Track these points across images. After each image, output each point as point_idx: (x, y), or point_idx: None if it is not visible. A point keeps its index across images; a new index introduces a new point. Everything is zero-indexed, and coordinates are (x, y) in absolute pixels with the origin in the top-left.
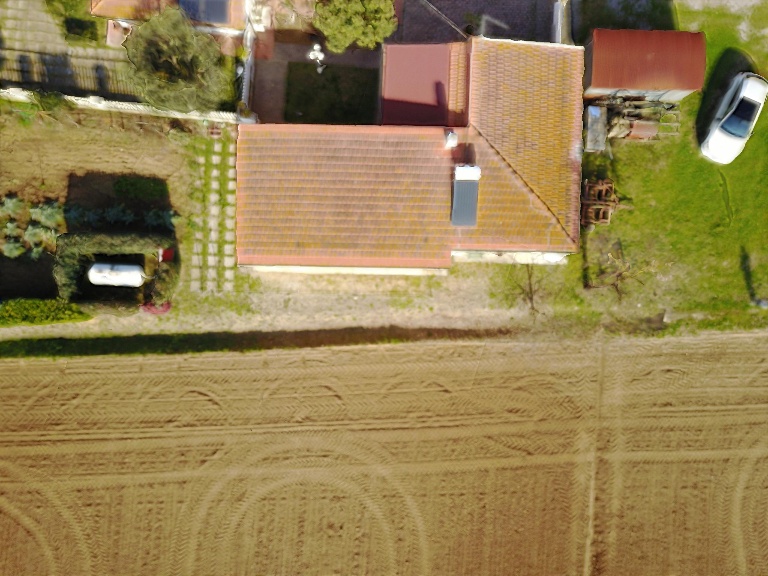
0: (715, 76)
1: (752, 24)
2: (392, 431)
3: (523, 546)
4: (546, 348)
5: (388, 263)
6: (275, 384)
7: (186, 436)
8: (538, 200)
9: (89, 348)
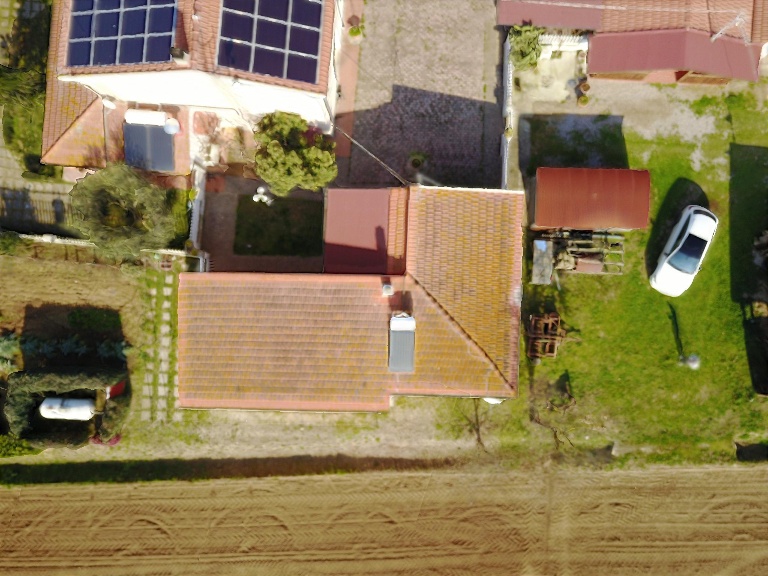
0: (664, 207)
1: (702, 155)
2: (337, 562)
3: None
4: (493, 479)
5: (327, 407)
6: (222, 513)
7: (135, 565)
8: (475, 347)
9: (43, 475)
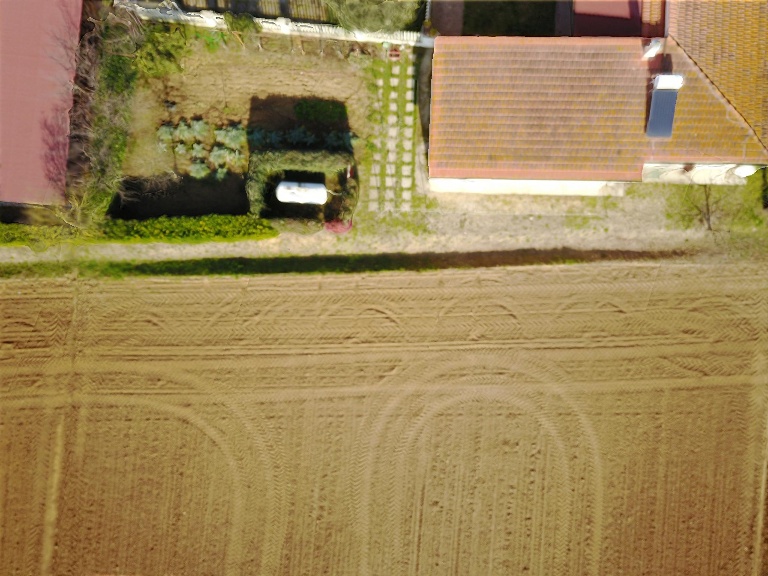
0: None
1: None
2: (567, 350)
3: (700, 466)
4: (722, 270)
5: (579, 176)
6: (451, 303)
7: (365, 352)
8: (735, 111)
9: (269, 267)
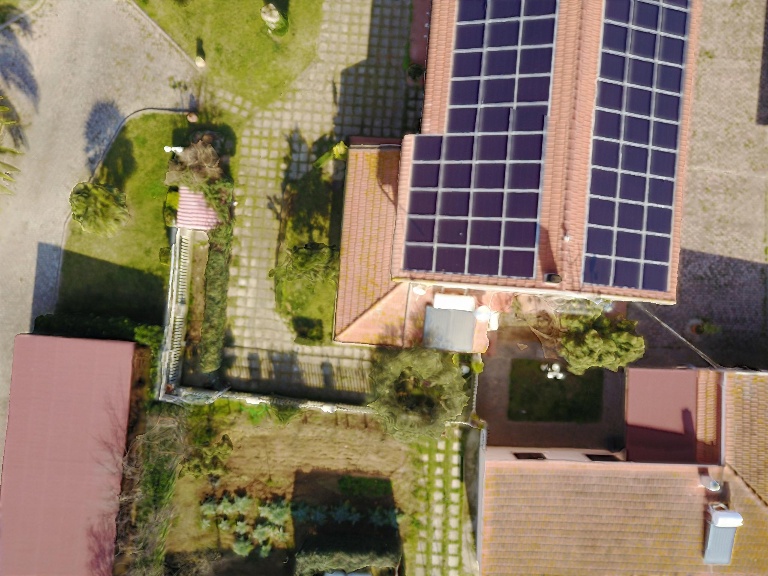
0: None
1: None
2: None
3: None
4: None
5: None
6: None
7: None
8: None
9: None
